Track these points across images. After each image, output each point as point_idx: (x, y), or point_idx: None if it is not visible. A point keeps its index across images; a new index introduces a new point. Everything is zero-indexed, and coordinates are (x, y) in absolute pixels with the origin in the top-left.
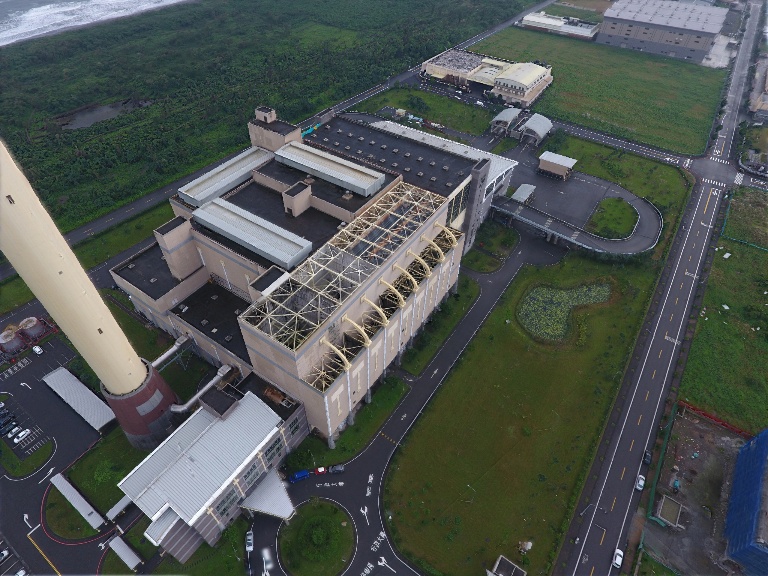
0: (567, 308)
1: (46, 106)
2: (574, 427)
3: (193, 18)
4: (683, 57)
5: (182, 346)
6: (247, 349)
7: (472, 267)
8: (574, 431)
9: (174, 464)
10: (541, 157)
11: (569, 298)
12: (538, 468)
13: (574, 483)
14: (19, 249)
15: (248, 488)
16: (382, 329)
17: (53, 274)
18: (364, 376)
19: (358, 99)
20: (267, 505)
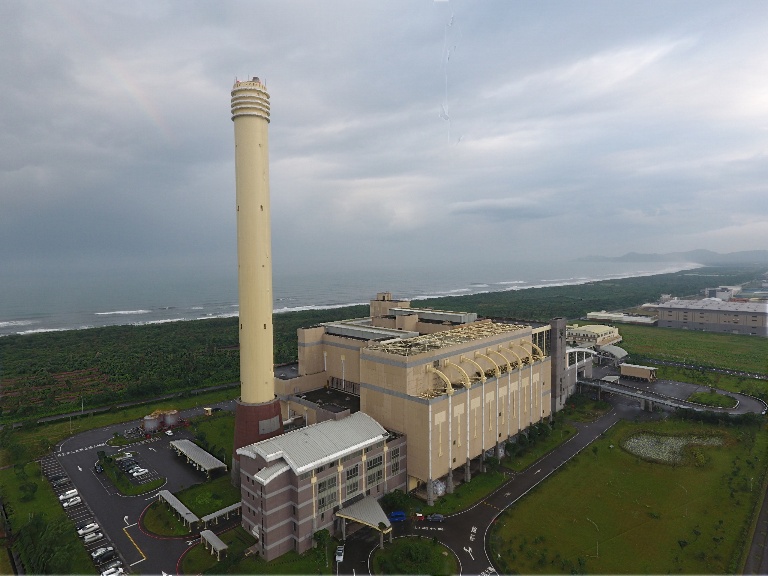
0: (677, 446)
1: (209, 343)
2: (714, 518)
3: (322, 314)
4: (747, 333)
5: (295, 421)
6: (360, 390)
7: (566, 418)
8: (715, 521)
9: (291, 434)
10: (621, 364)
11: (677, 441)
12: (677, 542)
13: (730, 557)
14: (251, 240)
15: (346, 499)
16: (480, 384)
17: (259, 265)
18: (464, 431)
19: None
20: (363, 516)
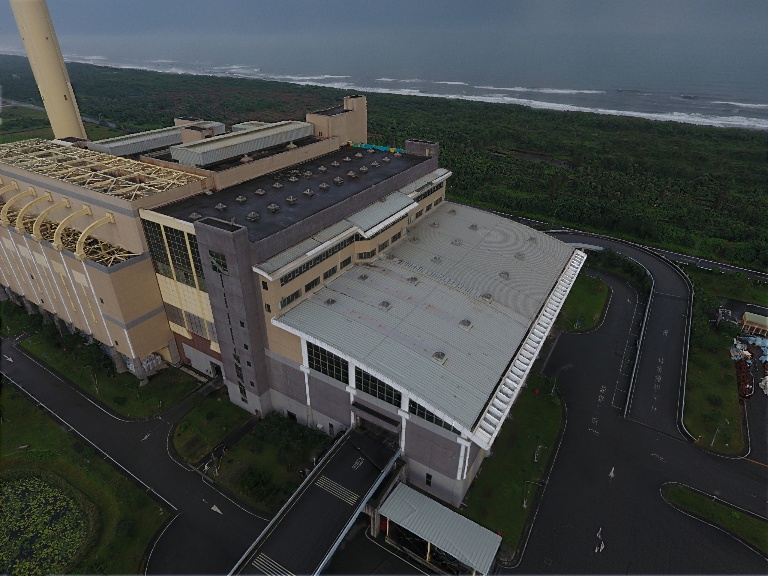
0: None
1: None
2: None
3: None
4: None
5: None
6: None
7: (196, 411)
8: None
9: None
10: None
11: None
12: None
13: None
14: None
15: None
16: None
17: None
18: None
19: (761, 277)
20: None
